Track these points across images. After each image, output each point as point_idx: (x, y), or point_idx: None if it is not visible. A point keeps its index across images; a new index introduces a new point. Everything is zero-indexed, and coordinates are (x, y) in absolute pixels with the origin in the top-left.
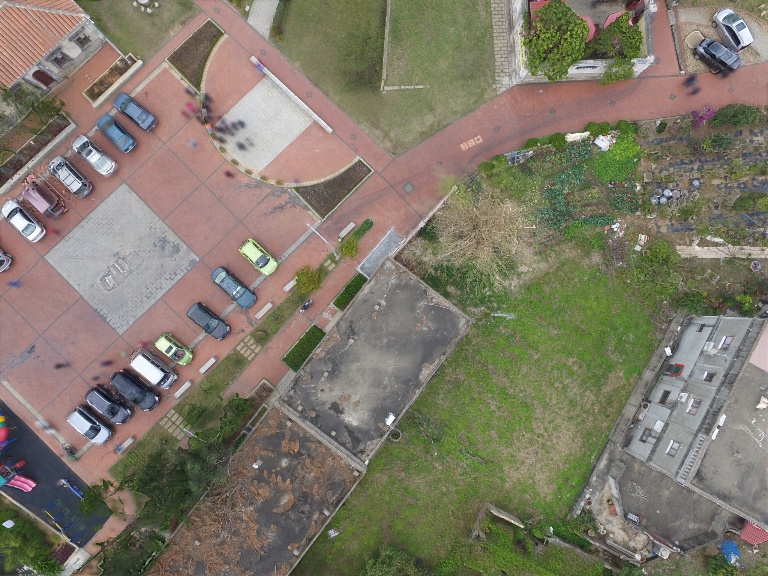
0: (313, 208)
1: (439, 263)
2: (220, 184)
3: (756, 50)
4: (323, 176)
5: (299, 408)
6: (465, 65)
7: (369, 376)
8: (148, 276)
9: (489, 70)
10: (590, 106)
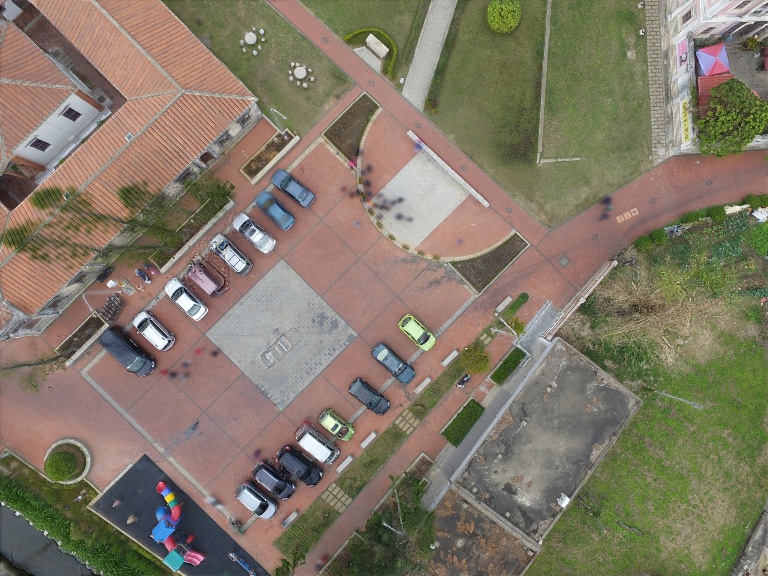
0: (470, 282)
1: (597, 337)
2: (377, 259)
3: None
4: (479, 250)
5: (474, 490)
6: (622, 136)
7: (541, 457)
8: (307, 352)
9: (646, 141)
10: (747, 177)
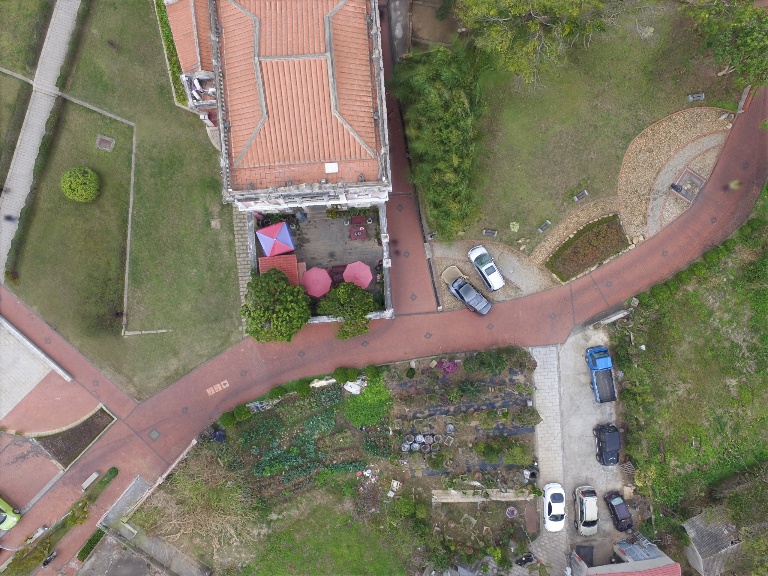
0: None
1: None
2: None
3: (517, 284)
4: (65, 424)
5: None
6: (209, 308)
7: None
8: None
9: (235, 312)
10: (341, 347)
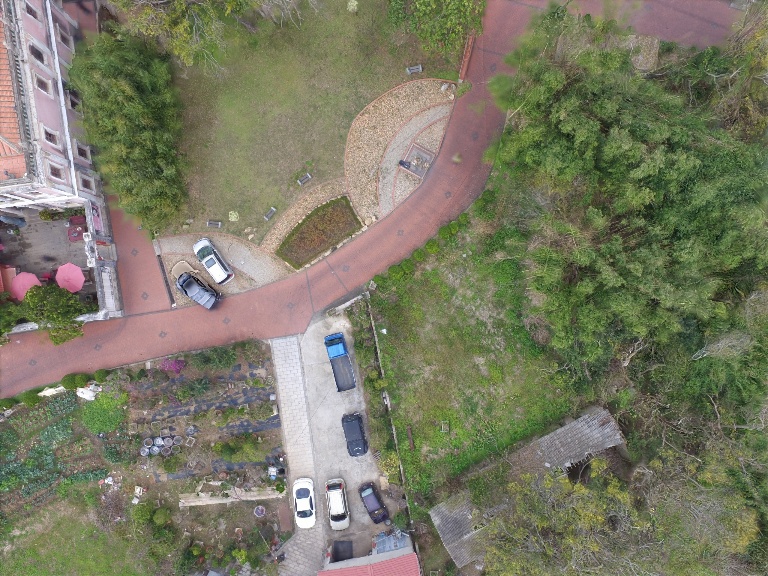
0: None
1: None
2: None
3: (250, 275)
4: None
5: None
6: None
7: None
8: None
9: None
10: (73, 353)
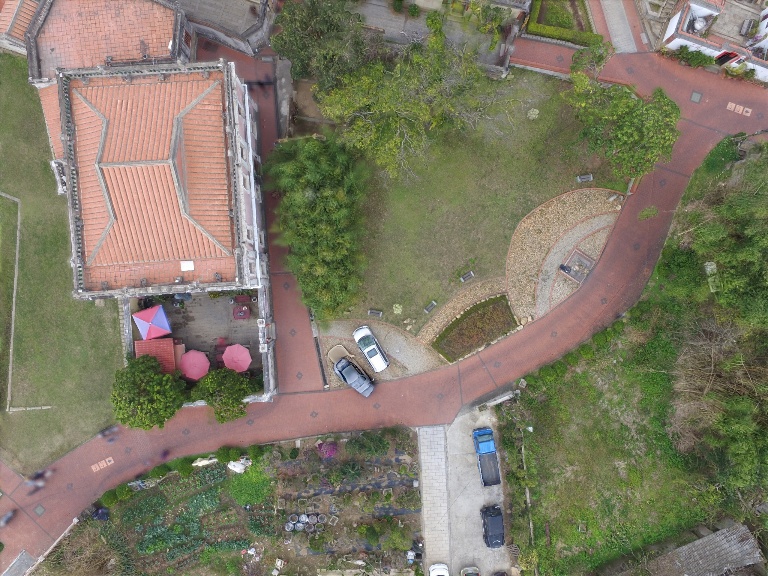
0: None
1: None
2: None
3: (403, 364)
4: None
5: None
6: (93, 385)
7: None
8: None
9: None
10: (226, 425)
